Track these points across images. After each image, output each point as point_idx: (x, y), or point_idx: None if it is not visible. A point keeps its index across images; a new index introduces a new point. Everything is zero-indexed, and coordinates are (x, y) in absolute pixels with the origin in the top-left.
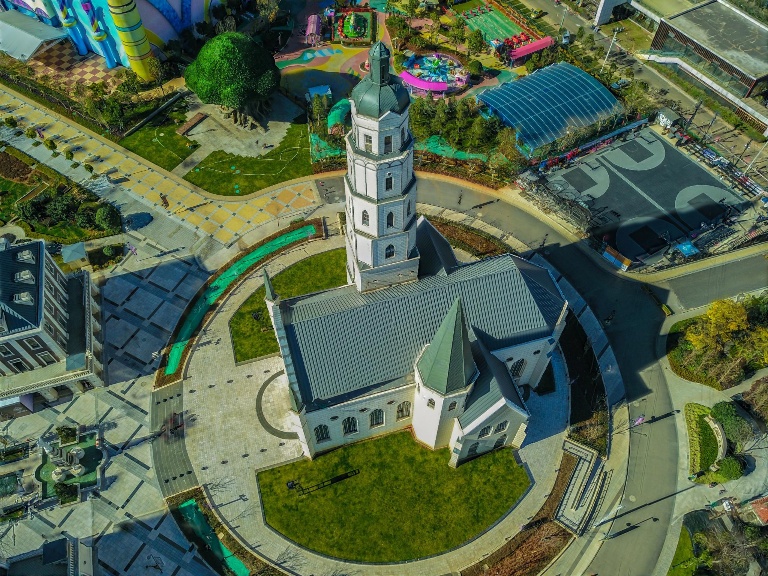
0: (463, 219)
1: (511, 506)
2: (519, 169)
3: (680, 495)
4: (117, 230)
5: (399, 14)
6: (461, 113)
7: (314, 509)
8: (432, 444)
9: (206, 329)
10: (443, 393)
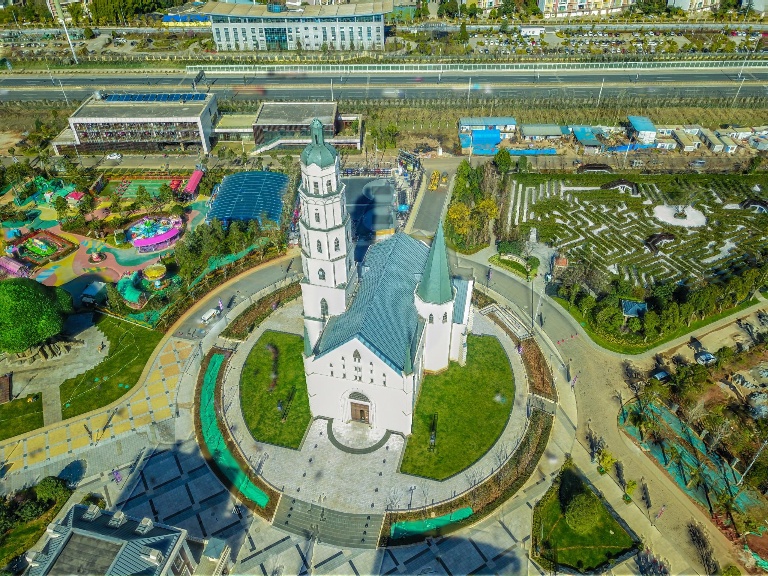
0: (291, 280)
1: (504, 352)
2: (282, 237)
3: (534, 289)
4: (67, 492)
5: (71, 218)
6: (220, 228)
7: (448, 448)
8: (446, 364)
9: (247, 459)
10: (451, 299)
